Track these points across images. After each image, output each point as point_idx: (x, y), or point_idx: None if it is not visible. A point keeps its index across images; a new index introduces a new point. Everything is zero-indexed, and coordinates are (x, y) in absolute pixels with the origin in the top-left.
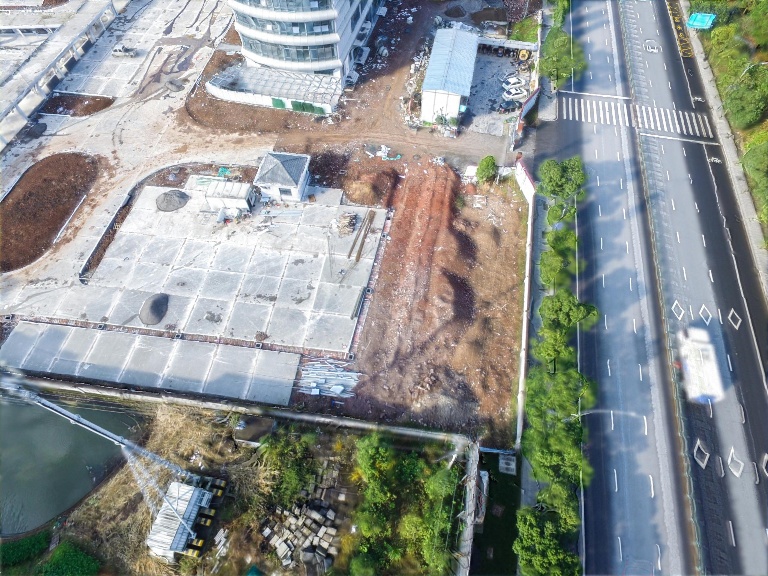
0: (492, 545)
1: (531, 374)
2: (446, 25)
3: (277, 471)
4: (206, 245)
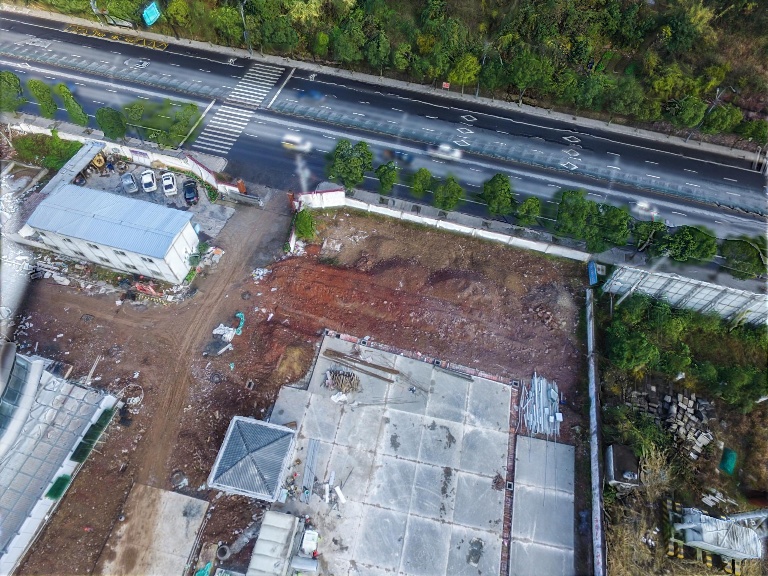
0: (687, 272)
1: (555, 227)
2: None
3: (652, 443)
4: None
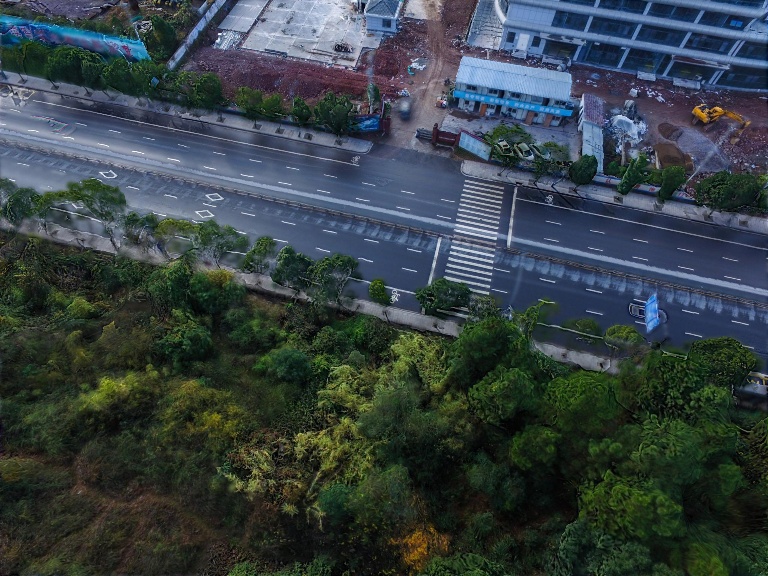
0: None
1: None
2: (635, 119)
3: None
4: (336, 0)
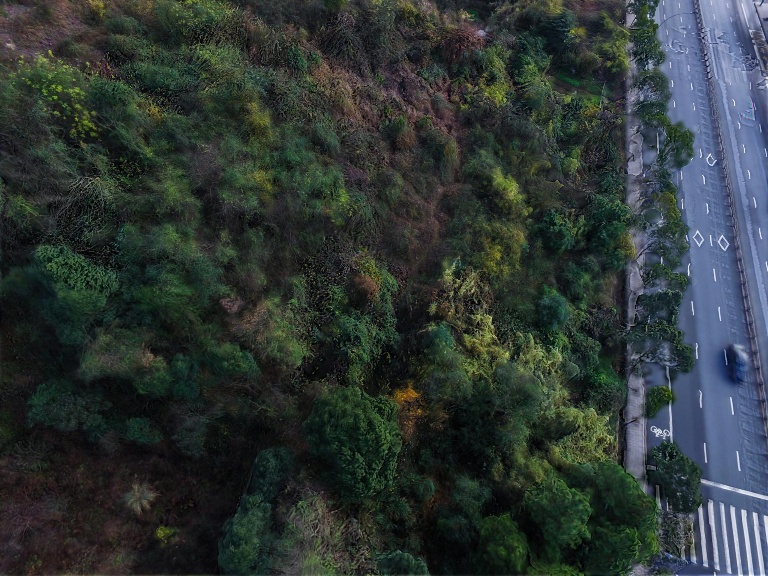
0: None
1: None
2: None
3: None
4: None
